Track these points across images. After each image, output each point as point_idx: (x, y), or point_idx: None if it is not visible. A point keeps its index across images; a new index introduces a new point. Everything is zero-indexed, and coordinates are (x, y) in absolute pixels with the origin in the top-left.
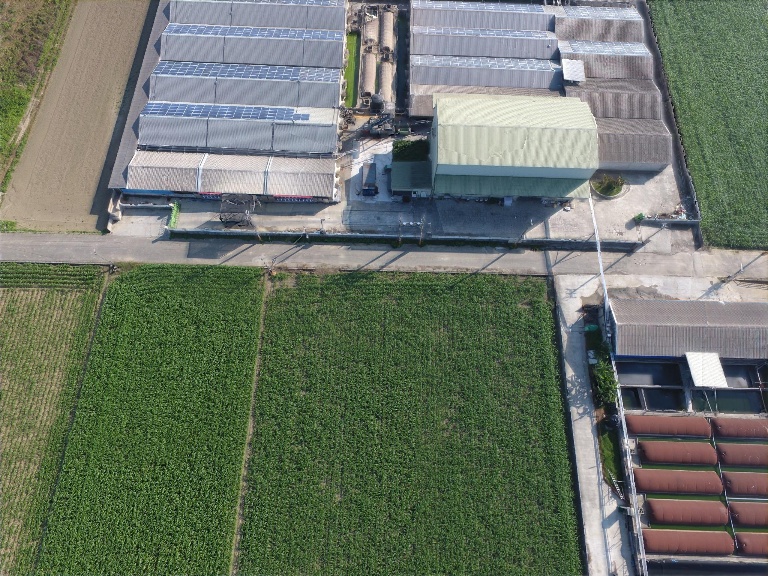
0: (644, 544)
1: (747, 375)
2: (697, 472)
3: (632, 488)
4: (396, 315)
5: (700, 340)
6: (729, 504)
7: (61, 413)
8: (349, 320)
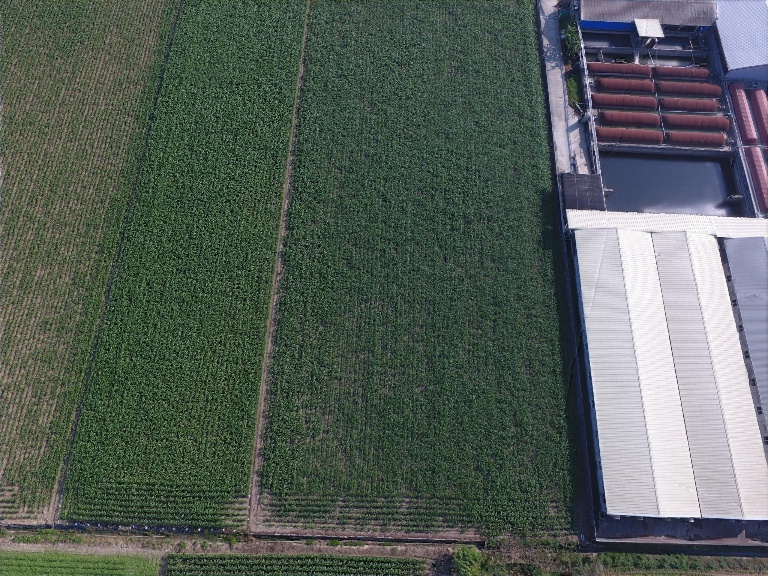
0: (596, 133)
1: (682, 44)
2: (639, 96)
3: (589, 99)
4: (412, 4)
5: (646, 11)
6: (661, 114)
7: (158, 56)
8: (376, 7)
